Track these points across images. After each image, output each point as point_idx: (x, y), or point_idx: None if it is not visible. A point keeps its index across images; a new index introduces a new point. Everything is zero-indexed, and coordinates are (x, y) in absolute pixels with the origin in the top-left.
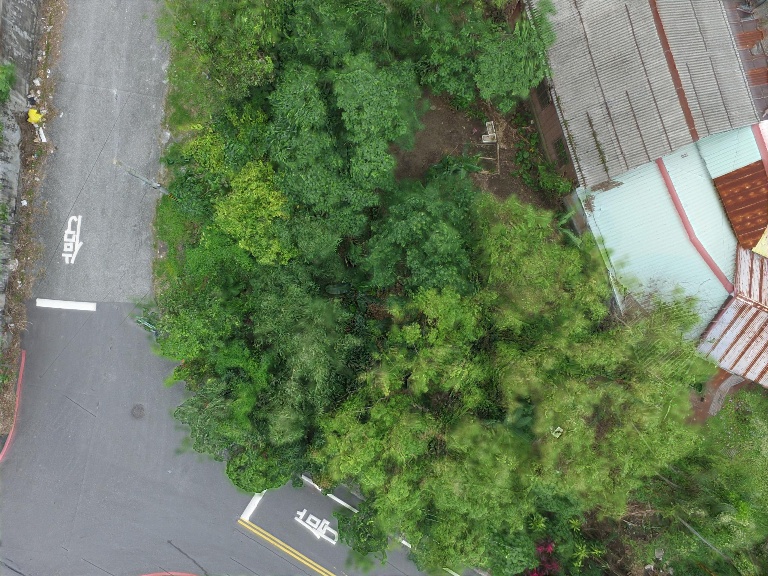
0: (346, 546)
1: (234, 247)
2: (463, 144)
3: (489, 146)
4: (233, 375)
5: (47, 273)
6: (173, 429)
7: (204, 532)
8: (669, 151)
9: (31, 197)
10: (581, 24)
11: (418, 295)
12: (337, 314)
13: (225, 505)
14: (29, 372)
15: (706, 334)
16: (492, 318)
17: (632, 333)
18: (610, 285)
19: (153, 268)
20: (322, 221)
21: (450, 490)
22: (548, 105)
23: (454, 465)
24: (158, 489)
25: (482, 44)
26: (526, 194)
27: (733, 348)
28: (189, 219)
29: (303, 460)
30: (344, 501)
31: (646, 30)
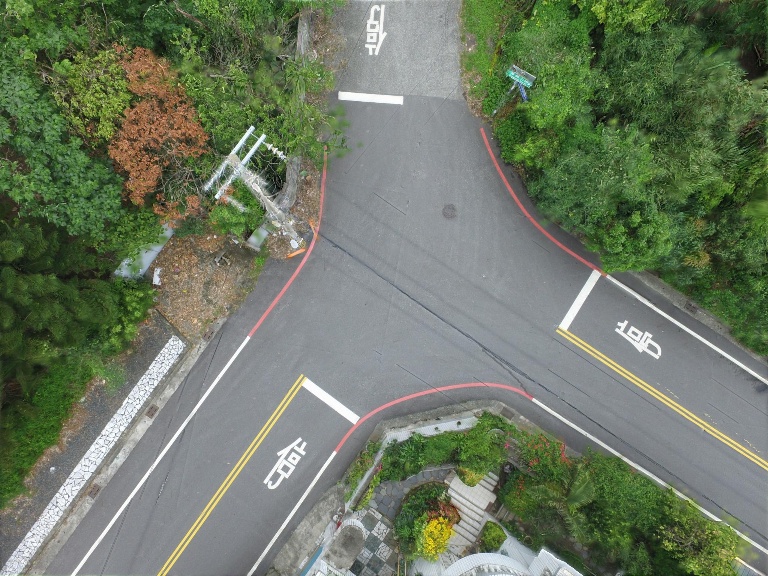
0: (670, 361)
1: (576, 21)
2: None
3: None
4: (584, 153)
5: (349, 65)
6: (486, 232)
7: (521, 341)
8: None
9: None
10: None
11: None
12: None
13: (542, 313)
14: (333, 168)
15: None
16: None
17: None
18: None
19: (461, 62)
20: None
21: None
22: None
23: None
24: (472, 294)
25: None
26: None
27: None
28: (497, 11)
29: (685, 231)
30: (667, 313)
31: None
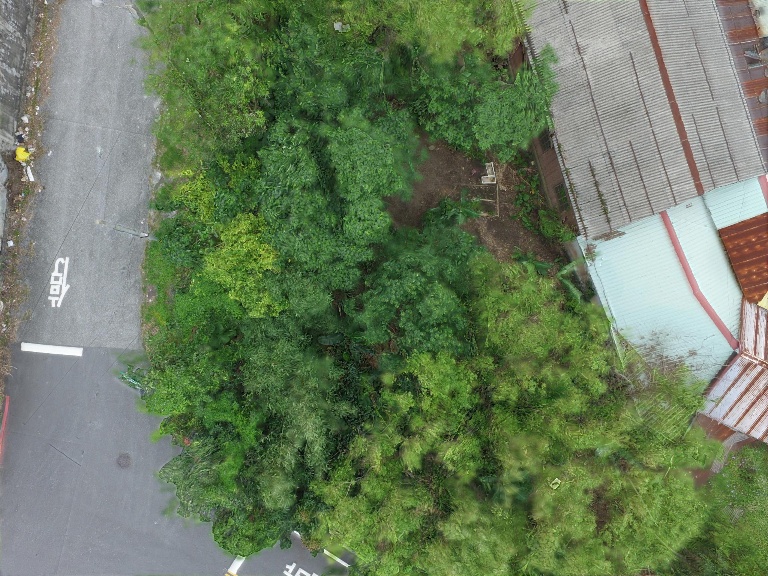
0: None
1: (224, 296)
2: (462, 185)
3: (488, 187)
4: (221, 429)
5: (33, 316)
6: (160, 479)
7: None
8: (673, 204)
9: (17, 237)
10: (584, 71)
11: (412, 356)
12: (330, 361)
13: (212, 558)
14: (12, 419)
15: (709, 390)
16: (489, 378)
17: (633, 386)
18: (611, 336)
19: (142, 312)
20: (314, 278)
21: (442, 570)
22: (549, 149)
23: (448, 524)
24: (143, 541)
25: (482, 94)
26: (526, 237)
27: (737, 405)
28: (179, 262)
29: (291, 522)
30: (335, 555)
31: (651, 79)
